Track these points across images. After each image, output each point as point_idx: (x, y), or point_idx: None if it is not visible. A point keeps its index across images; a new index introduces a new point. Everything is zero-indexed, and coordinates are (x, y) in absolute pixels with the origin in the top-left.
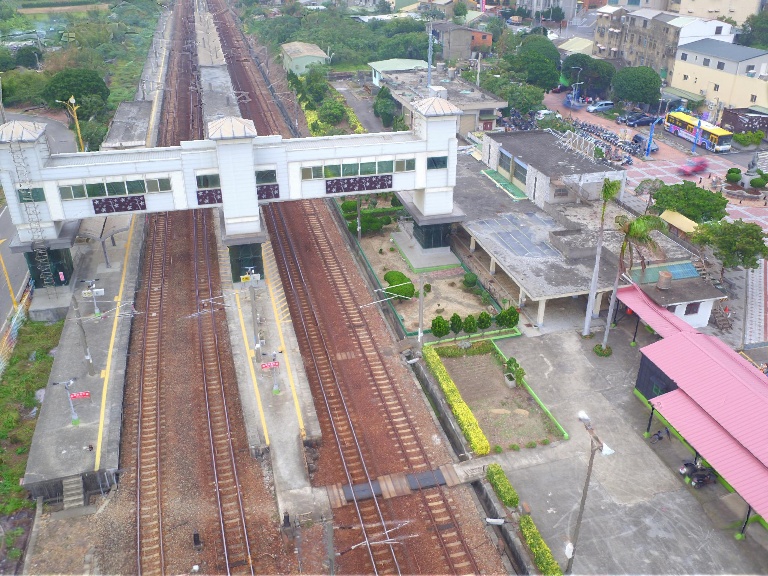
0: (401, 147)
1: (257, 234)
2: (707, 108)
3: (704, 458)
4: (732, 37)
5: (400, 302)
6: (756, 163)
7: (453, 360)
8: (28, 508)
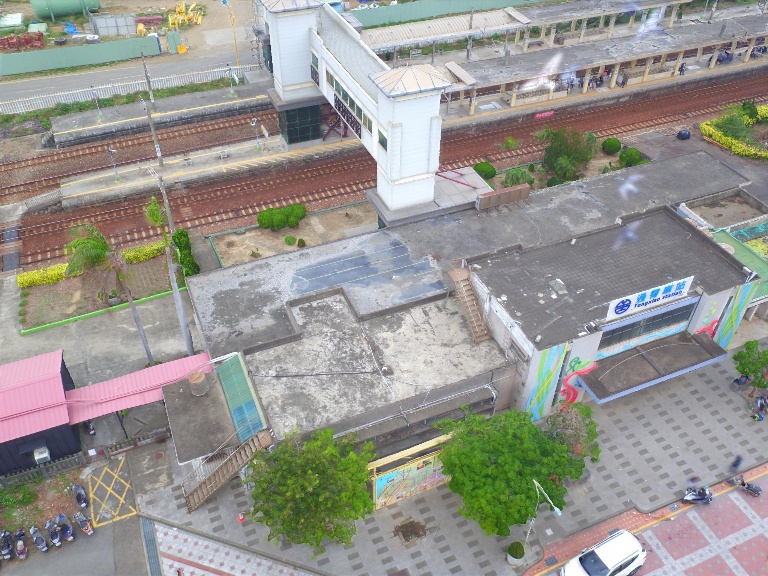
0: (366, 100)
1: (278, 101)
2: None
3: None
4: None
5: (272, 229)
6: None
7: (162, 267)
8: (47, 130)
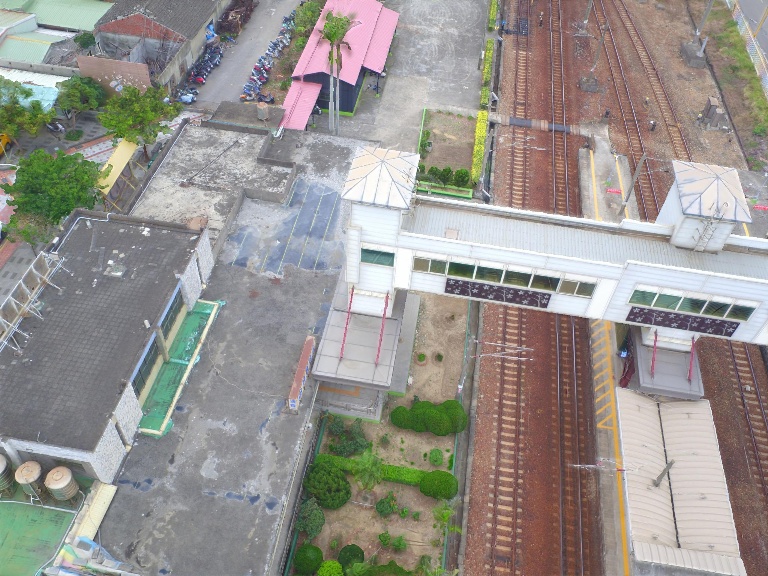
0: None
1: None
2: None
3: None
4: None
5: None
6: None
7: None
8: None
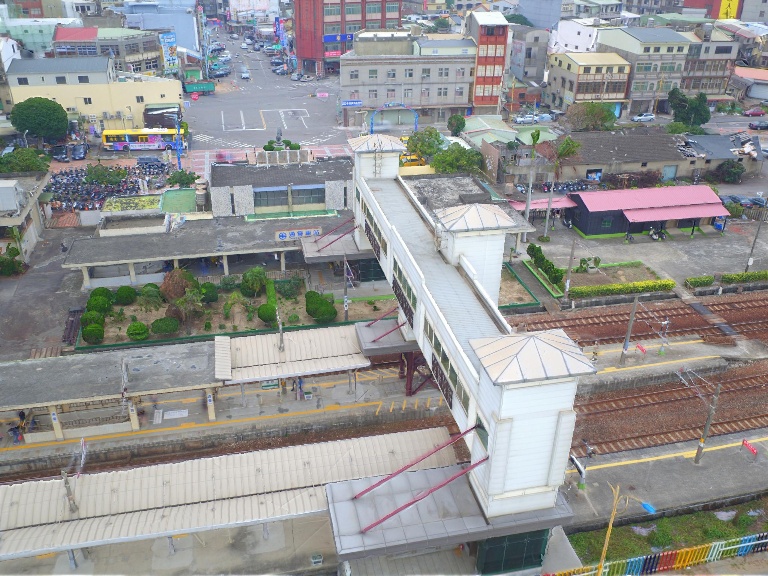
0: None
1: None
2: (86, 123)
3: (673, 219)
4: (19, 53)
5: None
6: (281, 135)
7: None
8: None
